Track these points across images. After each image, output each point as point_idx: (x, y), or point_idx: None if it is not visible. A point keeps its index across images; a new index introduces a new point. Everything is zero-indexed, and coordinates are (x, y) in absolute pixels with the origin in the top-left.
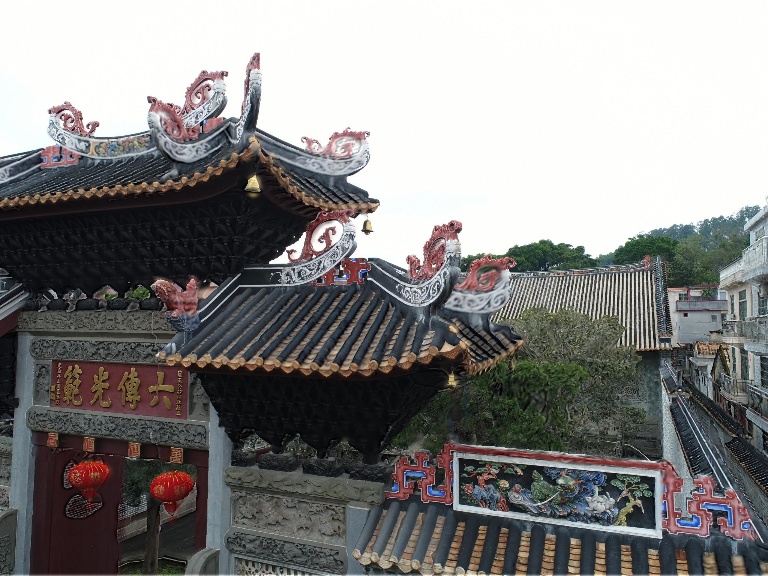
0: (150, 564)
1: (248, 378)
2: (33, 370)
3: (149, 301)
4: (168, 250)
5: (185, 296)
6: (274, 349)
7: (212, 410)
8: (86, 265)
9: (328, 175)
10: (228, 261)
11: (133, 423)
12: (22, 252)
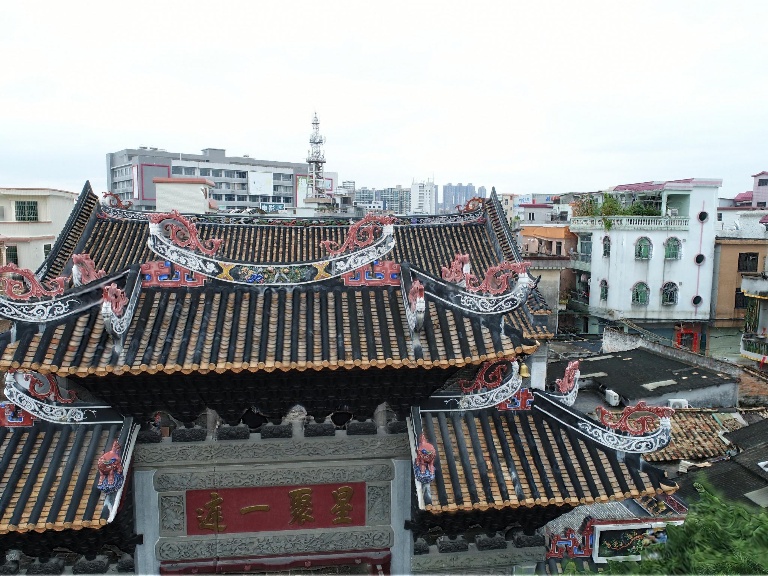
0: None
1: None
2: None
3: None
4: None
5: None
6: None
7: None
8: None
9: (38, 319)
10: None
11: None
12: None
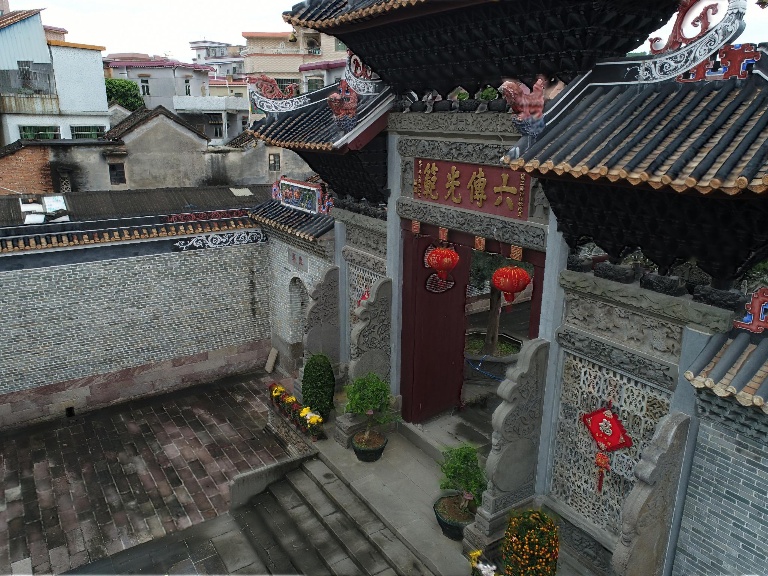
0: (491, 338)
1: (590, 186)
2: (400, 166)
3: (497, 102)
4: (517, 47)
5: (531, 98)
6: (621, 158)
7: (552, 214)
8: (441, 67)
9: None
10: (579, 56)
11: (479, 219)
12: (389, 56)
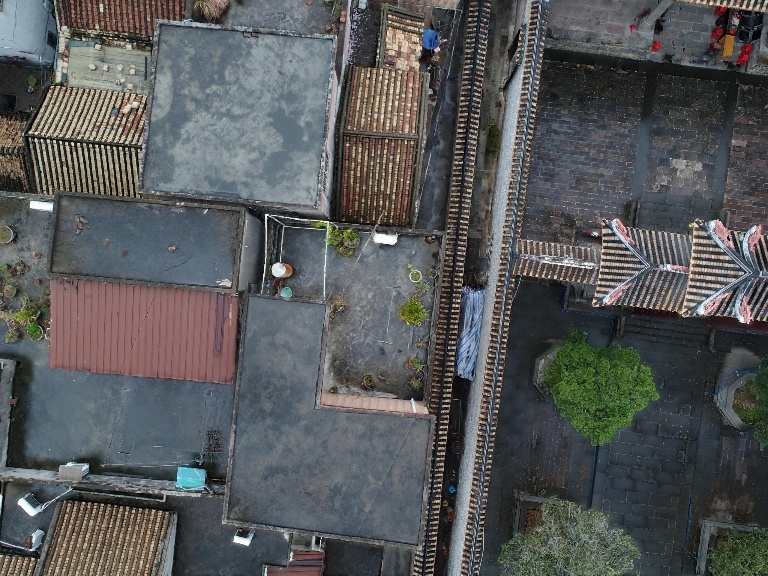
0: None
1: None
2: None
3: None
4: None
5: None
6: None
7: None
8: None
9: None
10: None
11: None
12: None
